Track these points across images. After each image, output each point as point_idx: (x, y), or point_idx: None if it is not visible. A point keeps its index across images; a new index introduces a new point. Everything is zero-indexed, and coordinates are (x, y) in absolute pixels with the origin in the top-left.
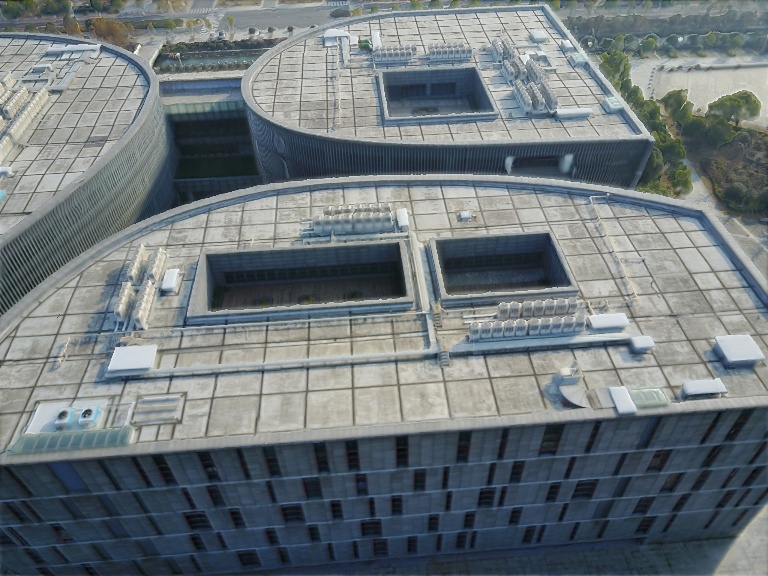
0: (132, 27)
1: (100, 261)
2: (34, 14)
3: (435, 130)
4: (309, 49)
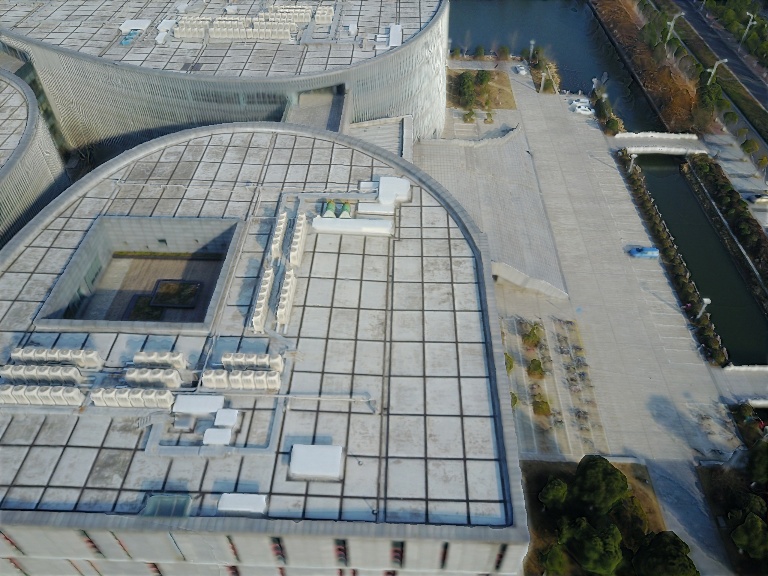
0: (734, 120)
1: (8, 84)
2: (760, 60)
3: (52, 259)
4: (356, 169)
